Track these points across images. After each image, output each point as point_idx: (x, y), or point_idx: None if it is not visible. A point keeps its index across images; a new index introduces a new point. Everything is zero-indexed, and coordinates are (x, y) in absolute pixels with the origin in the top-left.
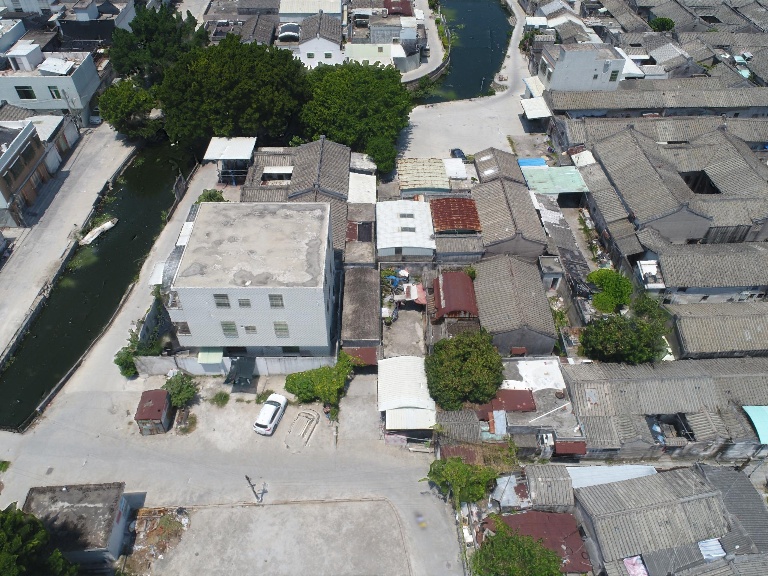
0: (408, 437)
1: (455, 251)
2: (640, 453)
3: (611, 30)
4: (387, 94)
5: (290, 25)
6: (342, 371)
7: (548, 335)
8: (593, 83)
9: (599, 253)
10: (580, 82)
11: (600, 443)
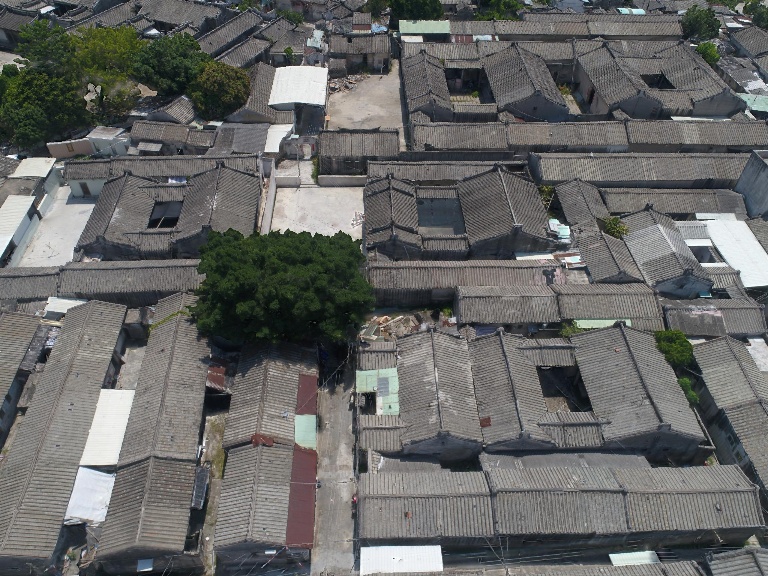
0: None
1: None
2: None
3: None
4: None
5: None
6: None
7: None
8: None
9: None
10: None
11: None
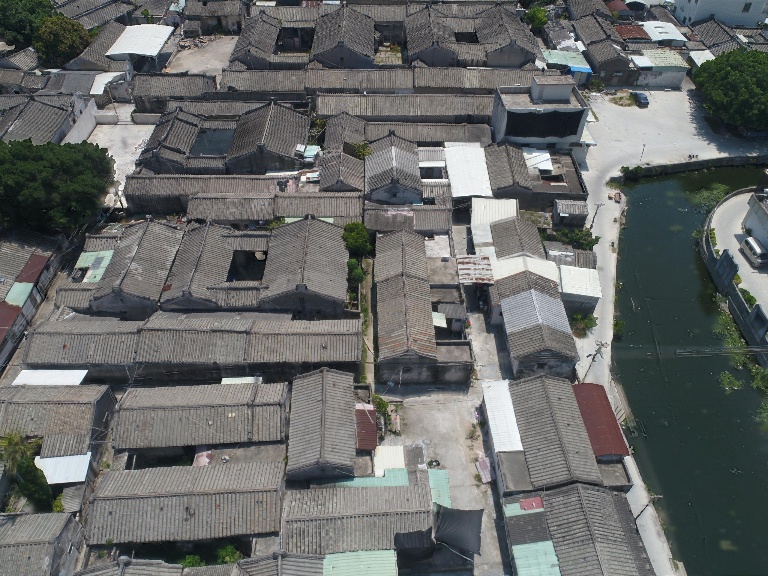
0: None
1: None
2: None
3: None
4: (732, 54)
5: None
6: None
7: None
8: None
9: (535, 37)
10: None
11: None
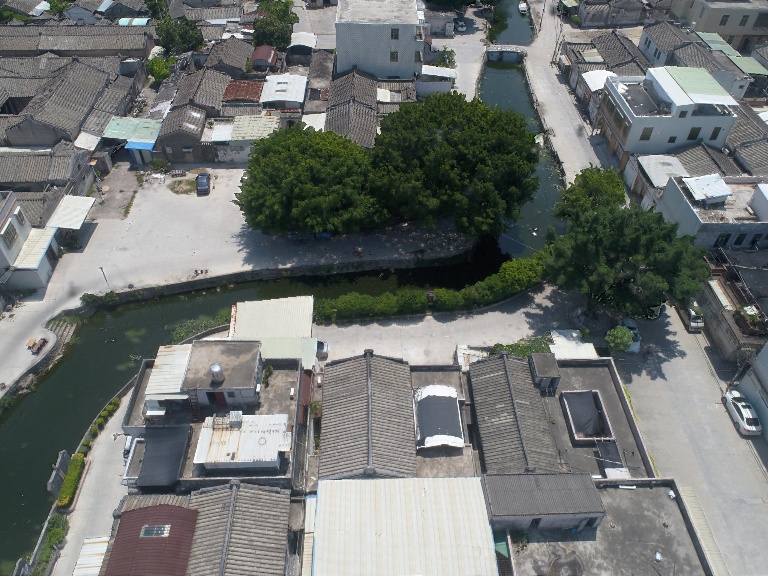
0: None
1: None
2: None
3: None
4: (273, 134)
5: (440, 427)
6: (334, 50)
7: None
8: None
9: None
10: None
11: None
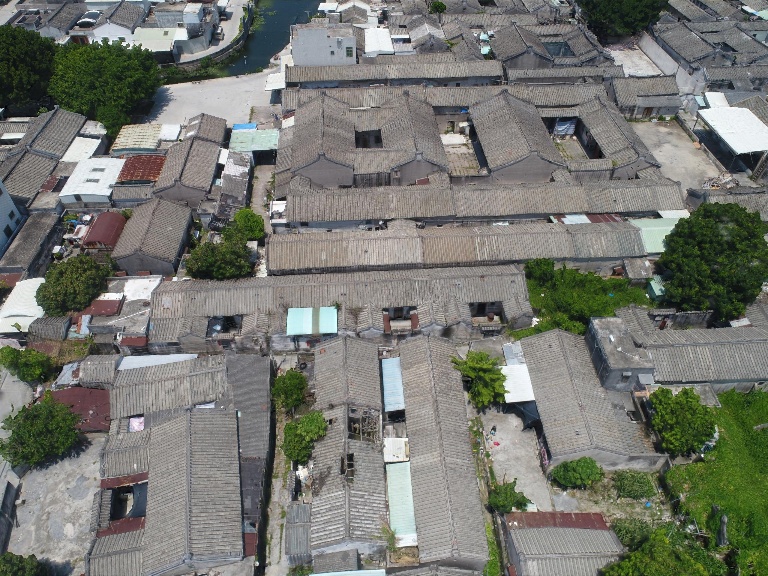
0: (15, 339)
1: (128, 198)
2: (202, 347)
3: (393, 14)
4: (117, 68)
5: (91, 12)
6: None
7: (162, 259)
8: (332, 59)
9: (264, 199)
10: (320, 58)
11: (162, 338)
